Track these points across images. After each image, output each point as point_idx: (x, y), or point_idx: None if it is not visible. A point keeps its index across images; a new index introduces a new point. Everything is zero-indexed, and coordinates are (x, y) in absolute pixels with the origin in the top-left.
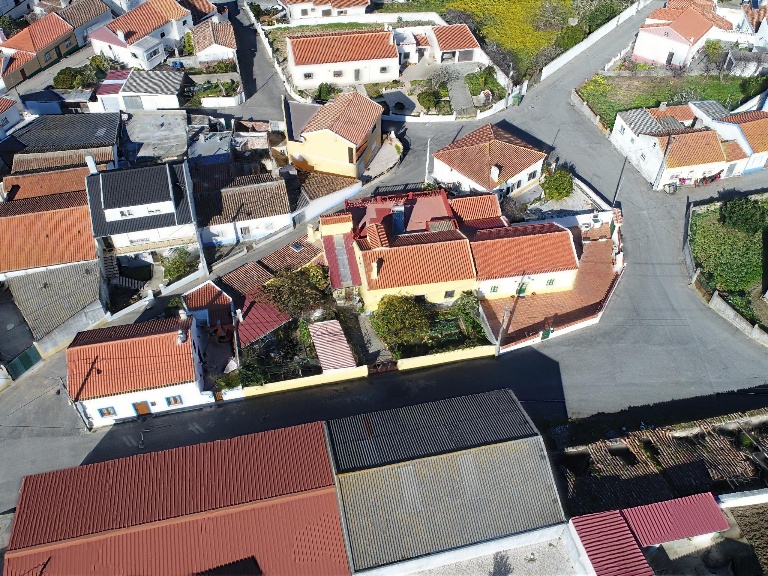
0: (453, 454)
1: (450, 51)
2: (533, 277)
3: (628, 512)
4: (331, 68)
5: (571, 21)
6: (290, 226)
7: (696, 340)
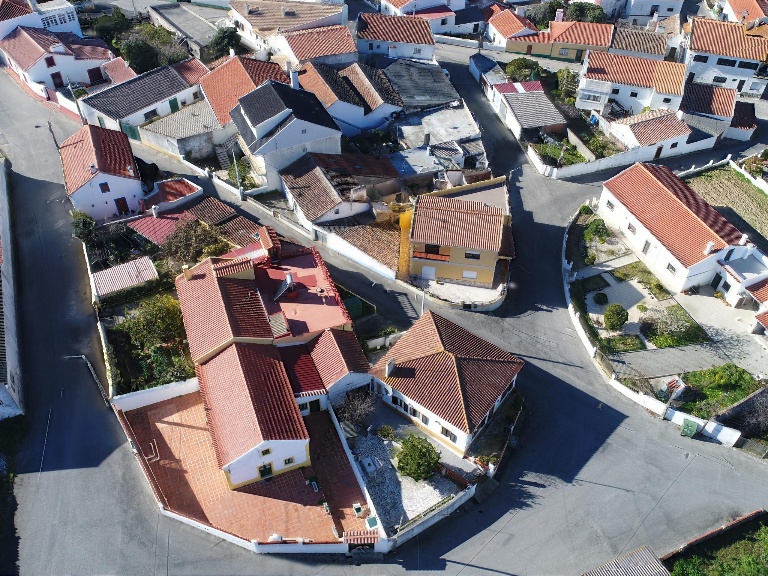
0: None
1: None
2: None
3: None
4: None
5: None
6: None
7: None
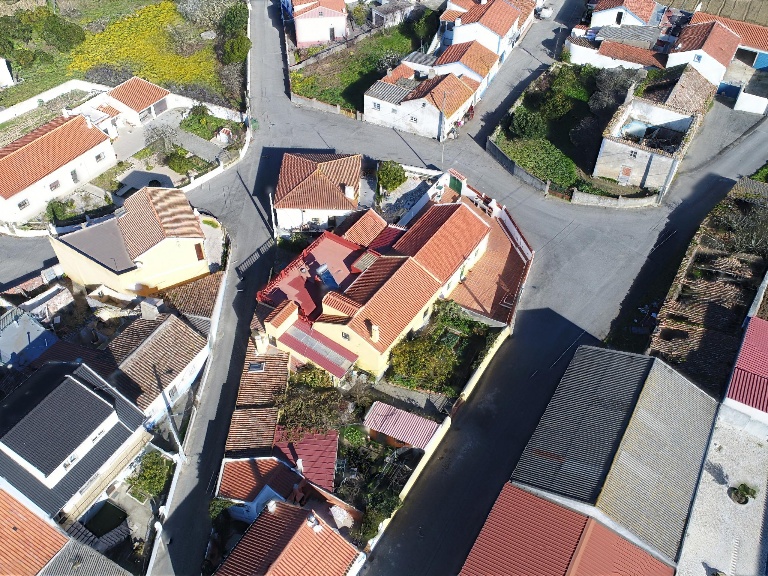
0: (633, 418)
1: (146, 109)
2: (469, 257)
3: (739, 365)
4: (45, 183)
5: (205, 36)
6: (210, 356)
7: (596, 231)
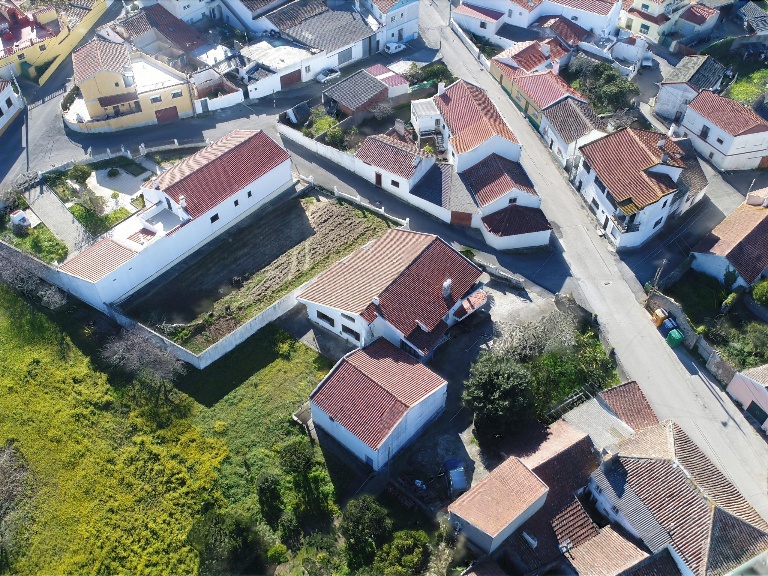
0: None
1: None
2: None
3: None
4: None
5: None
6: None
7: None
